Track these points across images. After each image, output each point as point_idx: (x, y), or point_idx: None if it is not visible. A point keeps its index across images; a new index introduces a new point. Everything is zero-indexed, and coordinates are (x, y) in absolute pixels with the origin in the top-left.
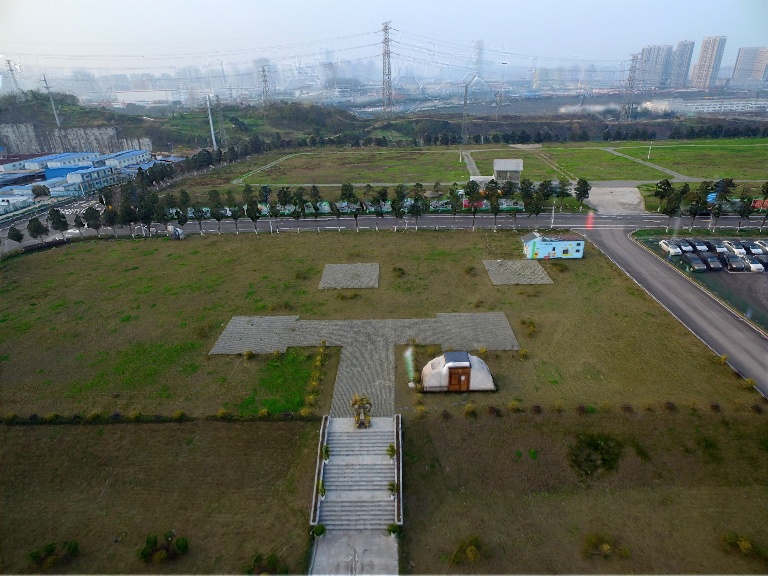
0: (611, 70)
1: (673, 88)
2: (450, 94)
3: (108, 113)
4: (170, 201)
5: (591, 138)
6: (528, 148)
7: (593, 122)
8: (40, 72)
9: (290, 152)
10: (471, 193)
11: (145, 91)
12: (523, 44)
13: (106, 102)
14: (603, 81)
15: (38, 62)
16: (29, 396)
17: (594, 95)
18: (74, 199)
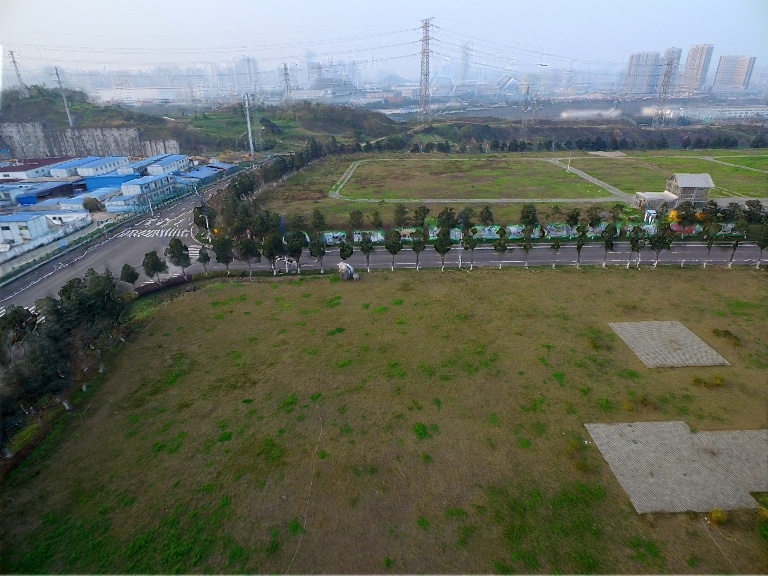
0: (646, 74)
1: (707, 94)
2: (482, 97)
3: (126, 112)
4: (297, 224)
5: (670, 146)
6: (616, 156)
7: (633, 128)
8: (43, 65)
9: (353, 158)
10: (689, 217)
11: (162, 88)
12: (564, 45)
13: (116, 100)
14: (638, 86)
15: (41, 54)
16: None
17: (628, 100)
18: (141, 216)
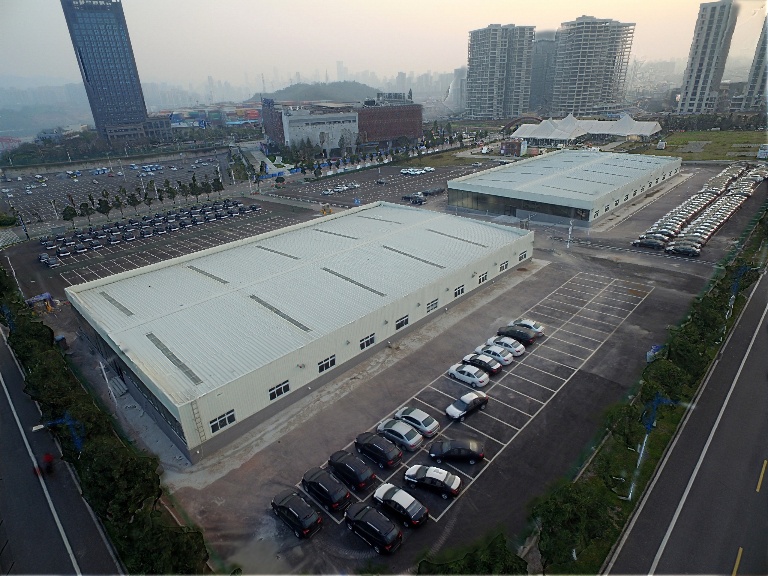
0: None
1: None
2: None
3: None
4: None
5: None
6: None
7: None
8: None
9: None
10: None
11: None
12: None
13: None
14: None
15: None
16: None
17: None
18: None
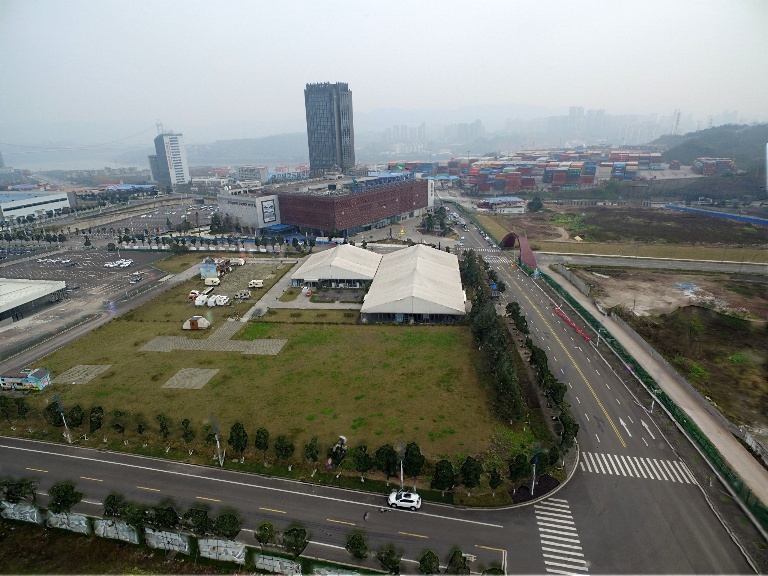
0: None
1: None
2: None
3: None
4: None
5: None
6: None
7: None
8: None
9: None
10: None
11: None
12: None
13: None
14: None
15: None
16: (354, 330)
17: None
18: None
